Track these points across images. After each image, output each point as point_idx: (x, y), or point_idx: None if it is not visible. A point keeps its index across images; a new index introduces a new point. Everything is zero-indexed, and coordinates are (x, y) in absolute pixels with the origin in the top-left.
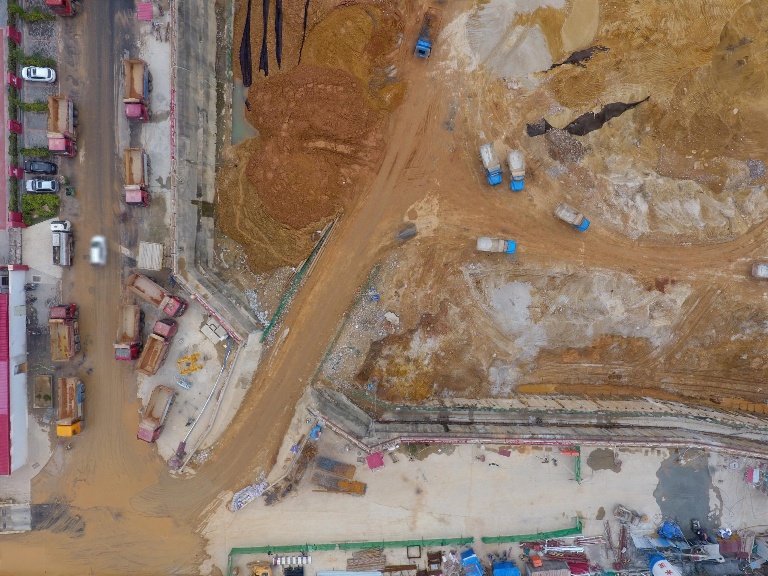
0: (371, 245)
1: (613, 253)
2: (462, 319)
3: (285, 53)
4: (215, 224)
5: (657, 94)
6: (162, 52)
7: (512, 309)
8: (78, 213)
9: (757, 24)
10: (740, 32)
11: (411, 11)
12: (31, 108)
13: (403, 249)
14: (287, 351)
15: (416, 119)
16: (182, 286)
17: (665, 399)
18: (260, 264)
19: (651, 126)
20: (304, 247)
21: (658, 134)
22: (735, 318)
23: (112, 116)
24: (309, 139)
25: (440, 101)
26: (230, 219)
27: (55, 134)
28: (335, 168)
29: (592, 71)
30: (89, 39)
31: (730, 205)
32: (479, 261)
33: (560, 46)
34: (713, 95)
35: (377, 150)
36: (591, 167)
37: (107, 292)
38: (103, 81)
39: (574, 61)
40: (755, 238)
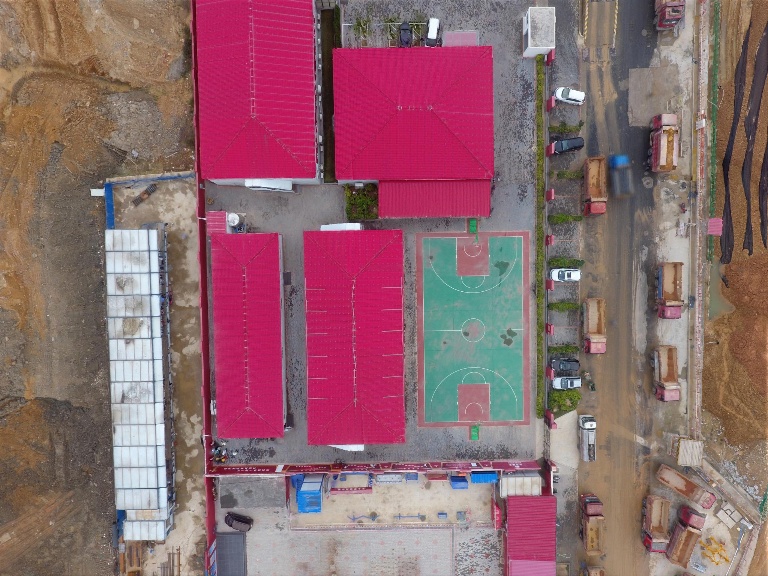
0: None
1: None
2: None
3: None
4: None
5: None
6: (681, 247)
7: None
8: (595, 405)
9: None
10: None
11: None
12: (558, 308)
13: None
14: None
15: None
16: (699, 473)
17: None
18: (740, 437)
19: None
20: None
21: None
22: None
23: (630, 310)
24: None
25: None
26: (712, 394)
27: (599, 339)
28: None
29: None
30: (609, 237)
31: None
32: None
33: None
34: None
35: None
36: None
37: (622, 480)
38: (622, 277)
39: None
40: None
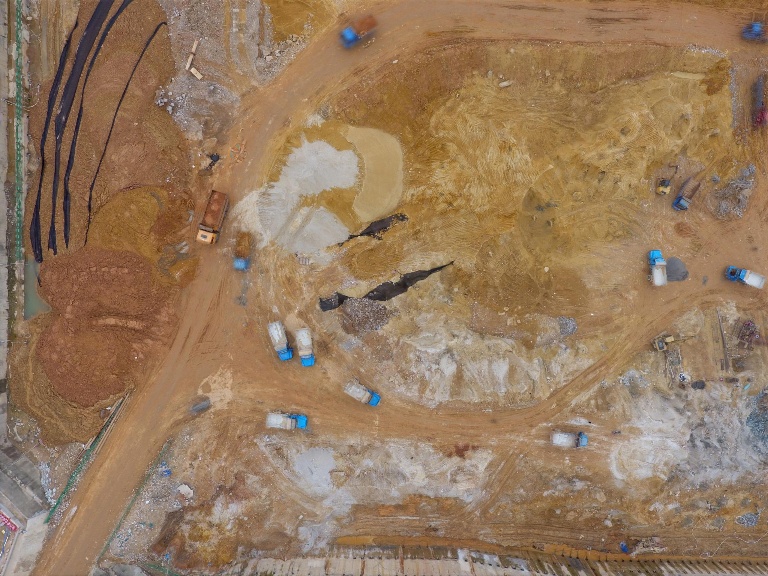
0: (163, 420)
1: (410, 423)
2: (263, 485)
3: (73, 233)
4: (8, 398)
5: (461, 259)
6: None
7: (311, 477)
8: None
9: (563, 187)
10: (547, 194)
11: (202, 189)
12: None
13: (196, 422)
14: (74, 529)
15: (208, 294)
16: None
17: (483, 550)
18: (52, 439)
19: (460, 286)
20: (91, 426)
21: (469, 292)
22: (543, 478)
23: None
24: (99, 316)
25: (232, 277)
26: (21, 395)
27: None
28: (126, 344)
29: (389, 242)
30: None
31: (535, 367)
32: (274, 433)
33: (355, 219)
34: (521, 256)
35: (170, 325)
36: (395, 331)
37: None
38: None
39: (371, 232)
40: (557, 402)
